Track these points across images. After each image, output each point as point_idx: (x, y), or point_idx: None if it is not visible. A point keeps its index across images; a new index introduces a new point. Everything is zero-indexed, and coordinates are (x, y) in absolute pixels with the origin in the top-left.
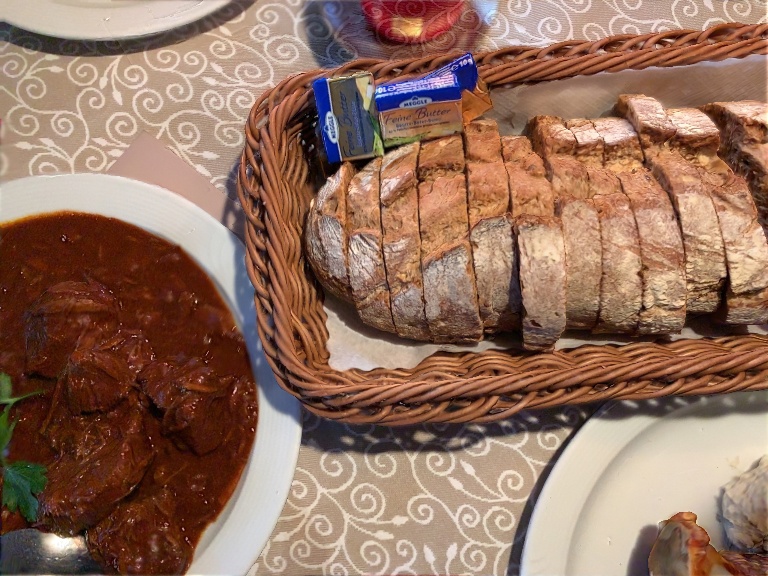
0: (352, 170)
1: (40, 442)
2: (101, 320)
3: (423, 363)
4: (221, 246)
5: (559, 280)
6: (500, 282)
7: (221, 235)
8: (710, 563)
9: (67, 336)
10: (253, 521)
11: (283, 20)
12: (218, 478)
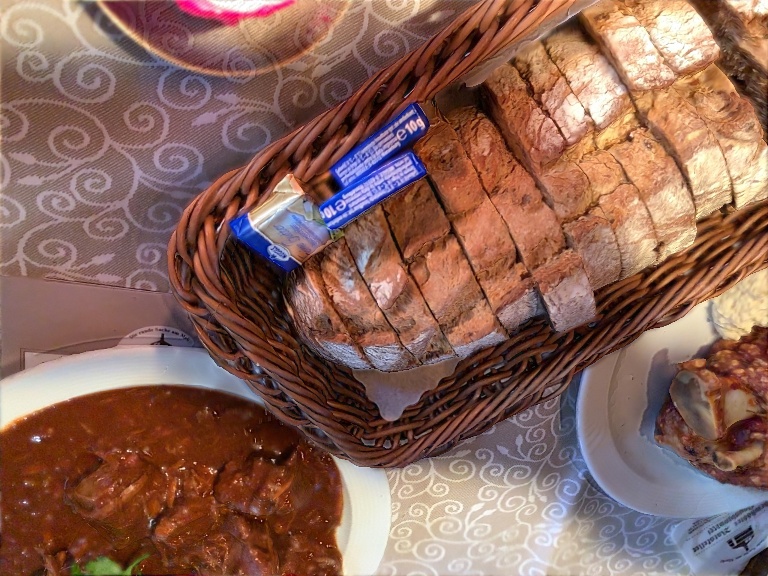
0: (314, 260)
1: (171, 570)
2: (149, 486)
3: (459, 366)
4: (208, 367)
5: (588, 306)
6: (526, 316)
7: (200, 359)
8: (723, 396)
9: (134, 518)
10: (373, 518)
11: (50, 29)
12: (326, 505)
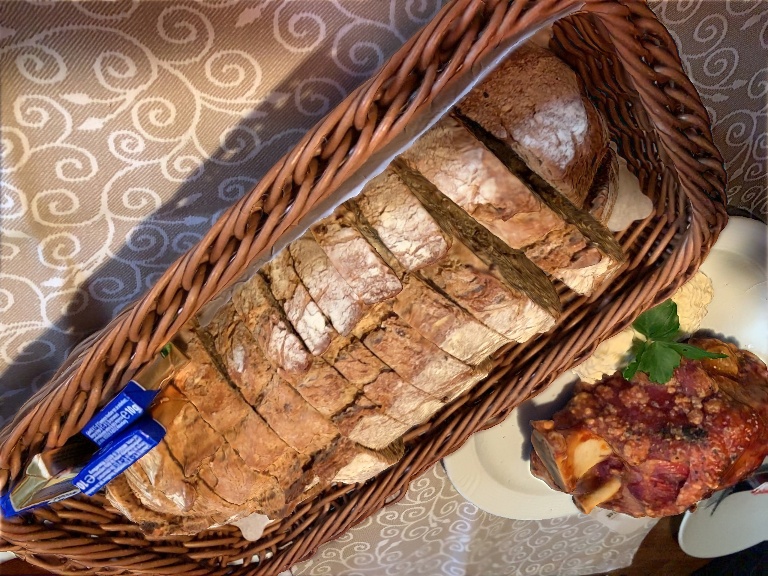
0: None
1: None
2: None
3: None
4: None
5: None
6: None
7: None
8: (572, 453)
9: None
10: None
11: None
12: None
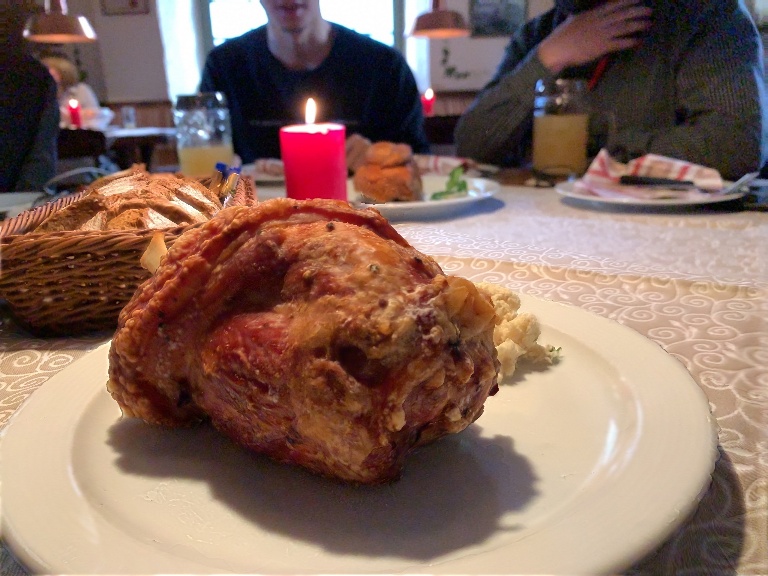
0: None
1: None
2: None
3: None
4: None
5: None
6: None
7: None
8: None
9: None
10: None
11: None
12: None
